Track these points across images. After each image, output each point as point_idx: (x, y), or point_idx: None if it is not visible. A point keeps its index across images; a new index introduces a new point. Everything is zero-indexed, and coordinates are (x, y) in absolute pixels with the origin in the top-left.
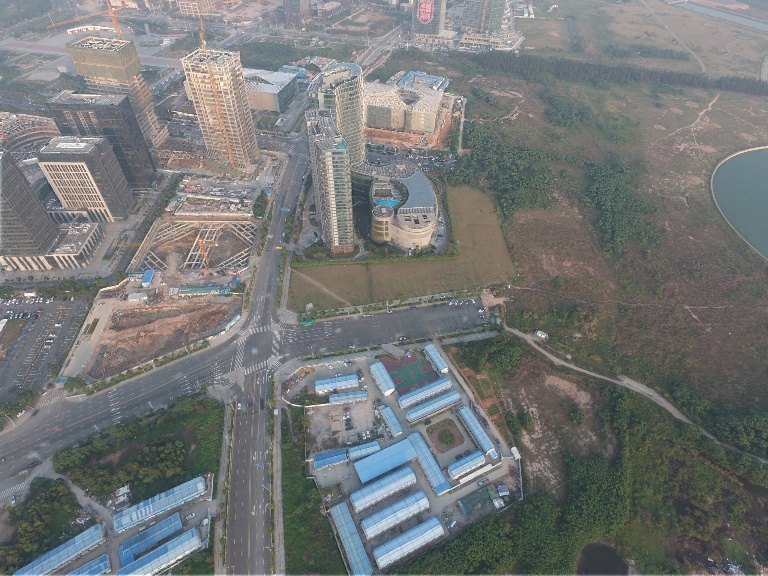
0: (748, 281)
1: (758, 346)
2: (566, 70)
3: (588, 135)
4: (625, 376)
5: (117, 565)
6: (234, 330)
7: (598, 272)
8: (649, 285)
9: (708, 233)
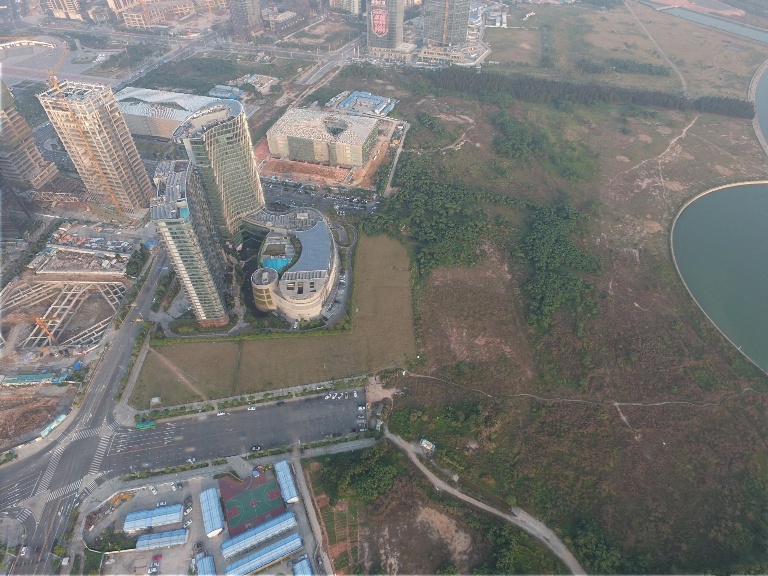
0: (697, 366)
1: (697, 463)
2: (526, 90)
3: (538, 169)
4: (520, 509)
5: None
6: (54, 435)
7: (515, 353)
8: (574, 372)
9: (658, 298)
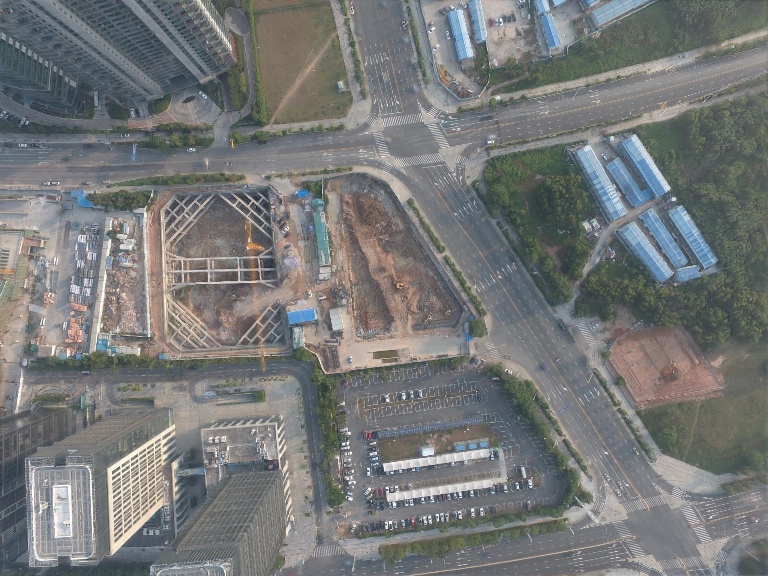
0: None
1: None
2: None
3: None
4: None
5: (646, 205)
6: (385, 176)
7: None
8: None
9: None
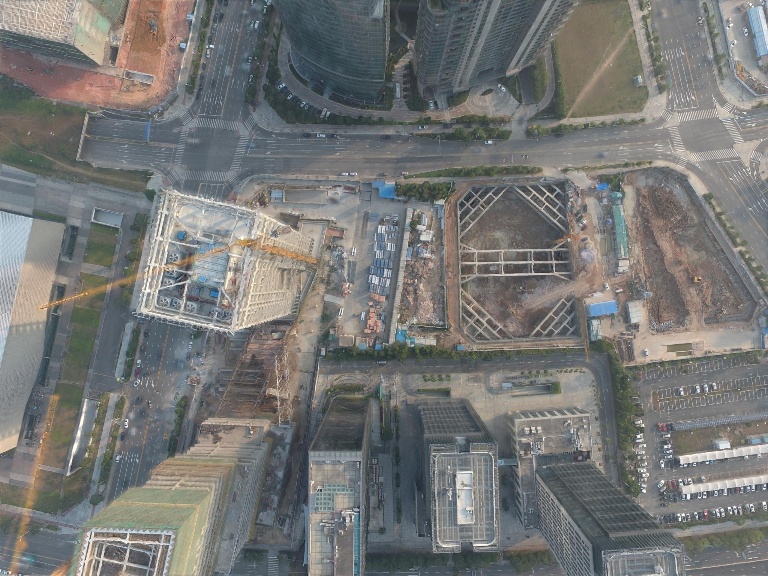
0: None
1: None
2: None
3: None
4: None
5: None
6: (680, 171)
7: None
8: None
9: None
